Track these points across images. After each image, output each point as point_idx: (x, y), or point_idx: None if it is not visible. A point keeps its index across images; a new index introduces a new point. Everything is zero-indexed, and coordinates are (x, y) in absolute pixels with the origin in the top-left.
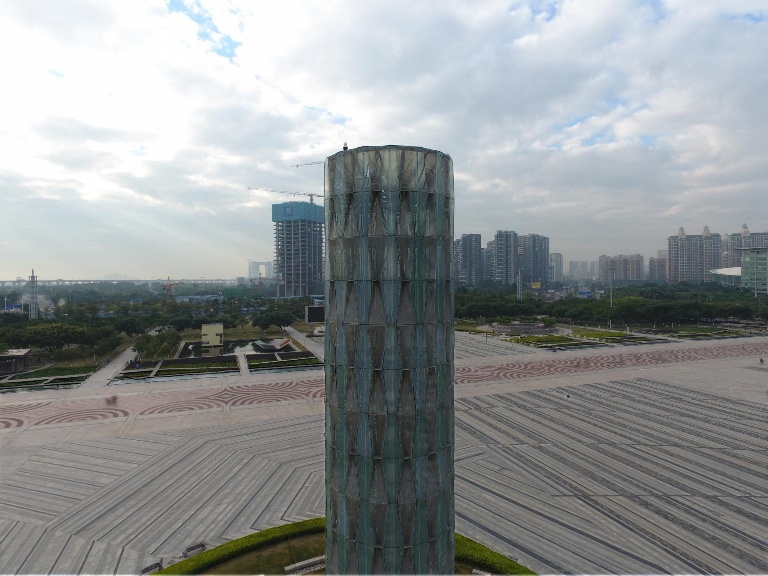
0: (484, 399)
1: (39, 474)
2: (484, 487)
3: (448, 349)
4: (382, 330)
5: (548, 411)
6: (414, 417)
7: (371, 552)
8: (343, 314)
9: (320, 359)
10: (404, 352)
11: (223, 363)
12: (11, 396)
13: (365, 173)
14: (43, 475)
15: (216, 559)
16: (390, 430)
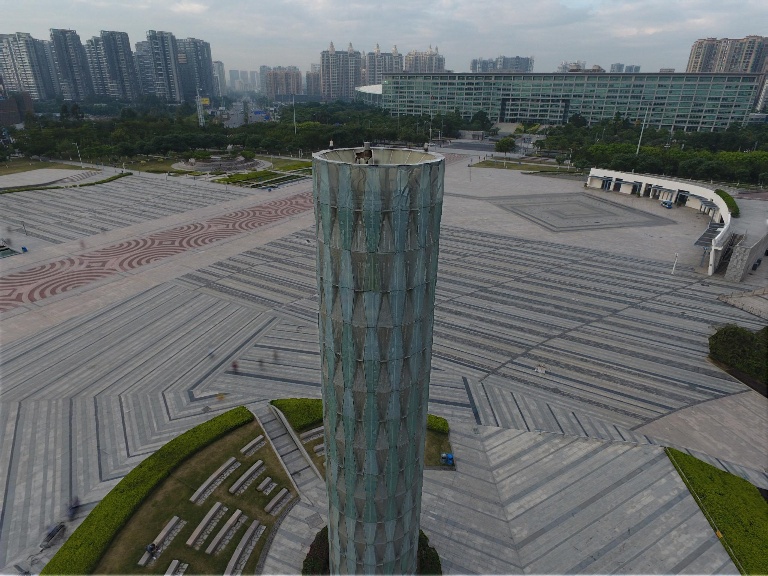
0: (239, 259)
1: None
2: (296, 350)
3: None
4: (411, 327)
5: (301, 260)
6: None
7: (397, 475)
8: (374, 319)
9: None
10: None
11: None
12: None
13: (402, 191)
14: None
15: (115, 532)
16: (412, 395)
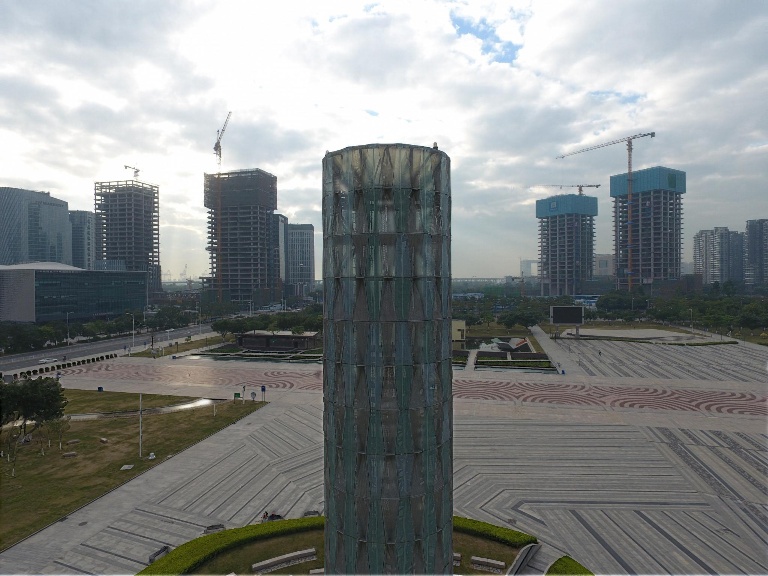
0: (752, 438)
1: (284, 425)
2: (681, 544)
3: (419, 350)
4: (342, 325)
5: None
6: (368, 414)
7: (336, 535)
8: None
9: (552, 363)
10: (361, 348)
11: (455, 357)
12: (296, 366)
13: None
14: (286, 426)
15: None
16: (349, 422)
